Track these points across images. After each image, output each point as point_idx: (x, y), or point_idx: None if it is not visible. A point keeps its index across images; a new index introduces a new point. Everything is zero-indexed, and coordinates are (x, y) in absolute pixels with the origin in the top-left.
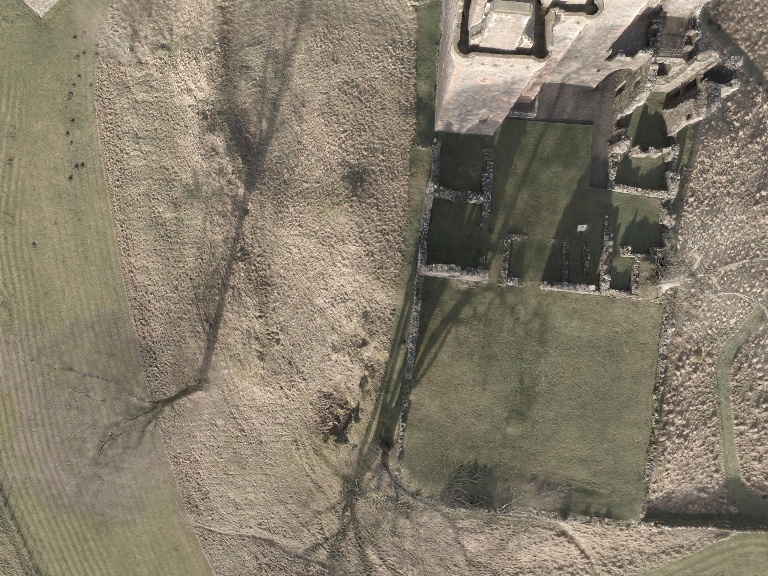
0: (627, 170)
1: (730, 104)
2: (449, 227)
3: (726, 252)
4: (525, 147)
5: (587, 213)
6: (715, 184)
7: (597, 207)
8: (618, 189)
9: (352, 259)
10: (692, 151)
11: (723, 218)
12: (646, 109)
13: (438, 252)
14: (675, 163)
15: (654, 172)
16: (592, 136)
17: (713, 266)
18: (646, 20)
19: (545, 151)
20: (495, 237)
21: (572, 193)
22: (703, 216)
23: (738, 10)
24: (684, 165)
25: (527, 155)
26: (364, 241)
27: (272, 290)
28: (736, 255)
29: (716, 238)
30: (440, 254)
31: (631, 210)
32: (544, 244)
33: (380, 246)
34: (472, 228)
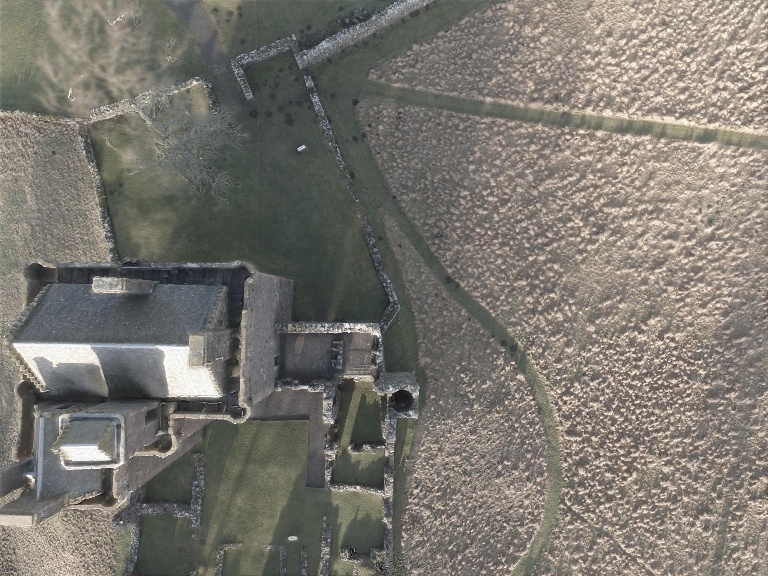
0: (346, 465)
1: (463, 376)
2: (160, 540)
3: (465, 533)
4: (237, 449)
5: (304, 515)
6: (448, 465)
7: (315, 508)
8: (334, 490)
9: (72, 567)
10: (414, 441)
11: (460, 497)
12: (364, 399)
13: (150, 566)
14: (392, 459)
15: (375, 465)
16: (308, 431)
17: (449, 552)
18: (332, 336)
19: (259, 451)
20: (207, 548)
21: (288, 495)
22: (434, 503)
23: (478, 264)
24: (406, 456)
25: (240, 457)
26: (80, 552)
27: (18, 575)
28: (478, 533)
29: (452, 521)
30: (152, 568)
31: (352, 508)
32: (261, 551)
33: (94, 558)
34: (184, 540)
